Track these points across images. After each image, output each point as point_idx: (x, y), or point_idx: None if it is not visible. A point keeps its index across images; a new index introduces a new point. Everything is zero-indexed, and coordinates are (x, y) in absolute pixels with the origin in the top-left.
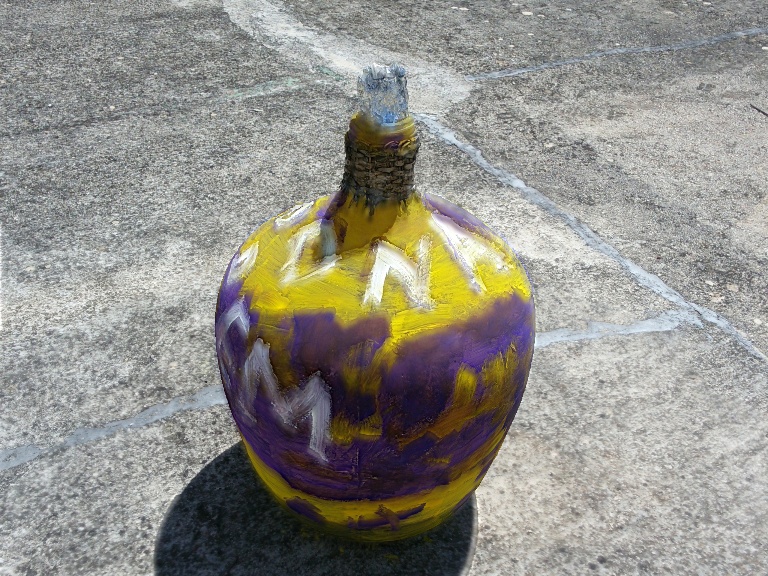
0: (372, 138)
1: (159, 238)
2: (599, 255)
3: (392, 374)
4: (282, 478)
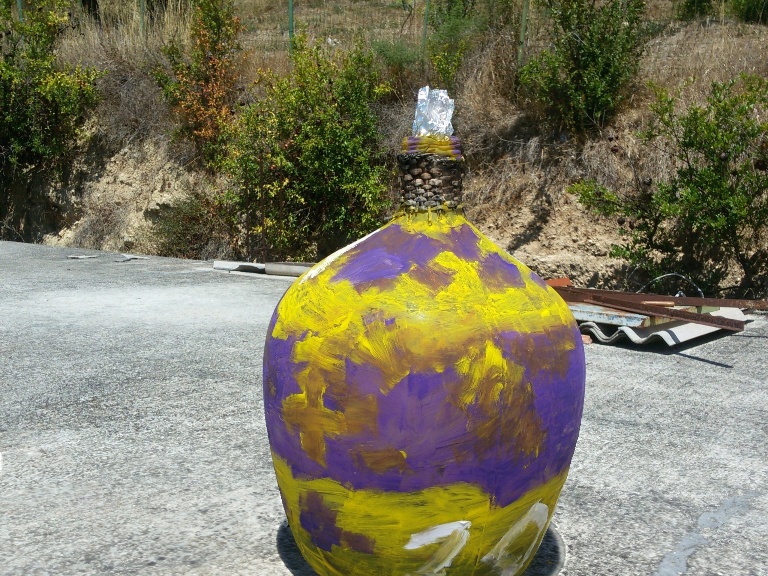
0: None
1: None
2: None
3: None
4: None
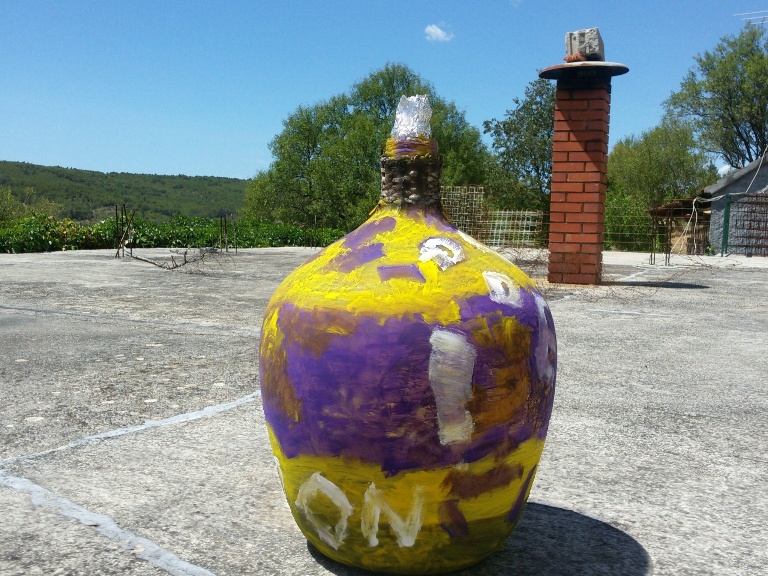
0: None
1: None
2: None
3: None
4: None
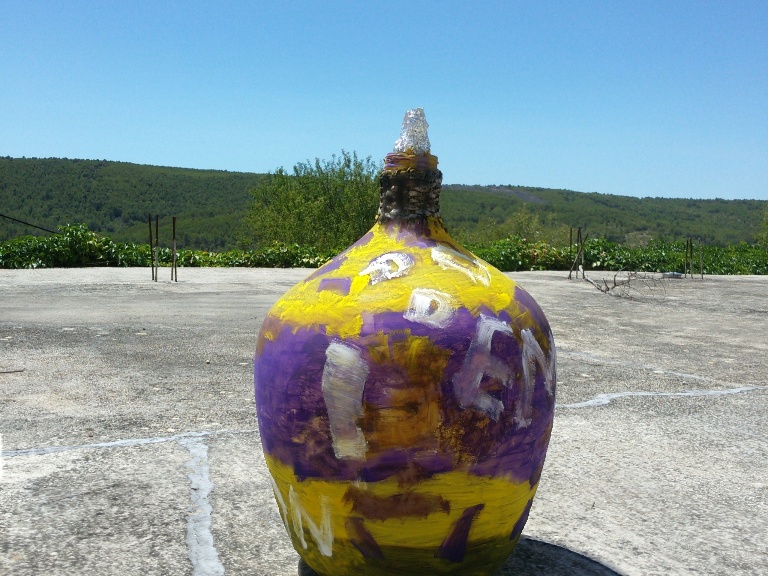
0: (436, 169)
1: None
2: (66, 452)
3: None
4: (528, 485)
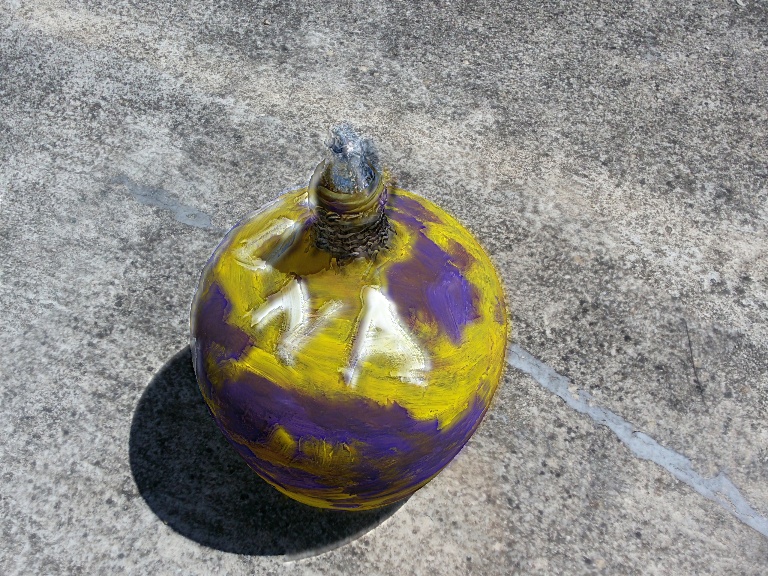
0: None
1: (477, 100)
2: None
3: (223, 386)
4: None
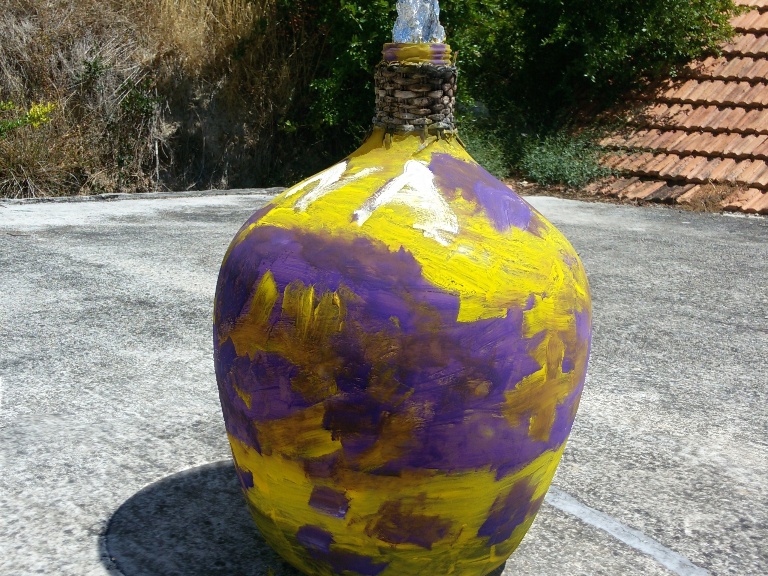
0: None
1: (643, 387)
2: None
3: None
4: None
